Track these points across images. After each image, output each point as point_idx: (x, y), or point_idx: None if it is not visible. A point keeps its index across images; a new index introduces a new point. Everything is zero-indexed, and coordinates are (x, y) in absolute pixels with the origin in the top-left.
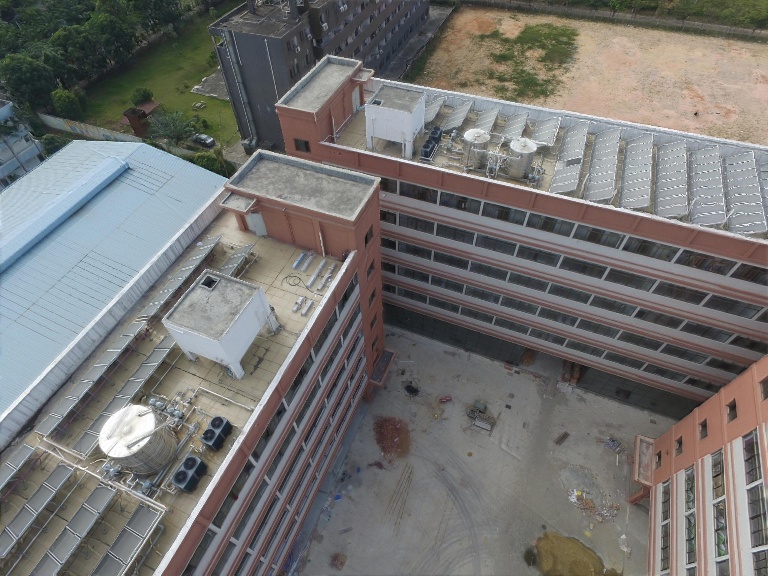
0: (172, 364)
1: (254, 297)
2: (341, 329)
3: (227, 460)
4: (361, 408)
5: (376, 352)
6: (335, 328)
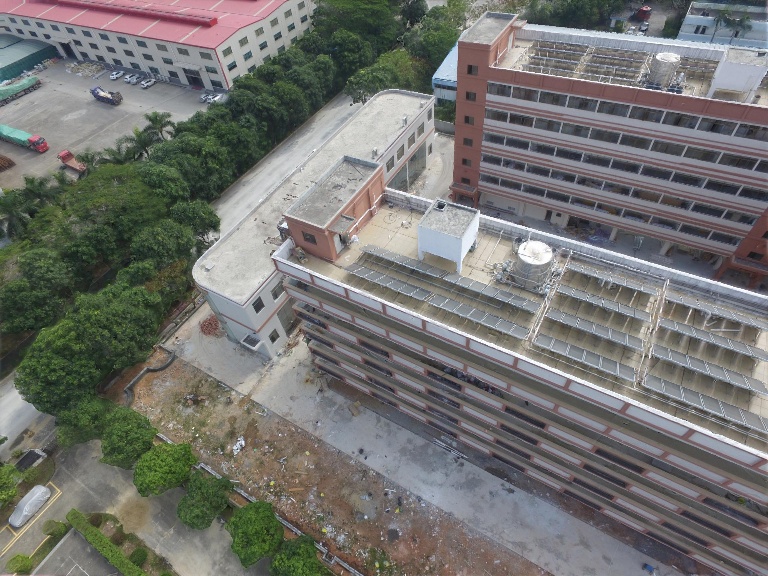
0: (704, 79)
1: (760, 67)
2: (764, 154)
3: (664, 91)
4: (706, 274)
5: (763, 247)
6: (762, 144)
